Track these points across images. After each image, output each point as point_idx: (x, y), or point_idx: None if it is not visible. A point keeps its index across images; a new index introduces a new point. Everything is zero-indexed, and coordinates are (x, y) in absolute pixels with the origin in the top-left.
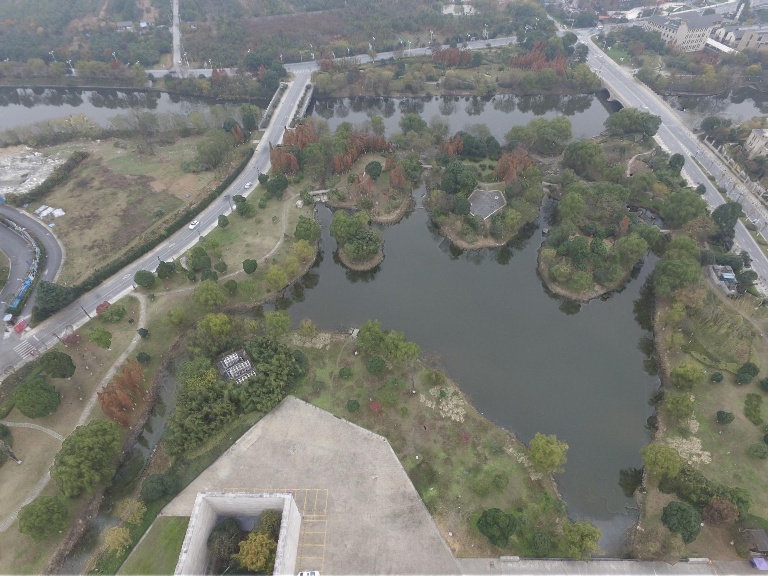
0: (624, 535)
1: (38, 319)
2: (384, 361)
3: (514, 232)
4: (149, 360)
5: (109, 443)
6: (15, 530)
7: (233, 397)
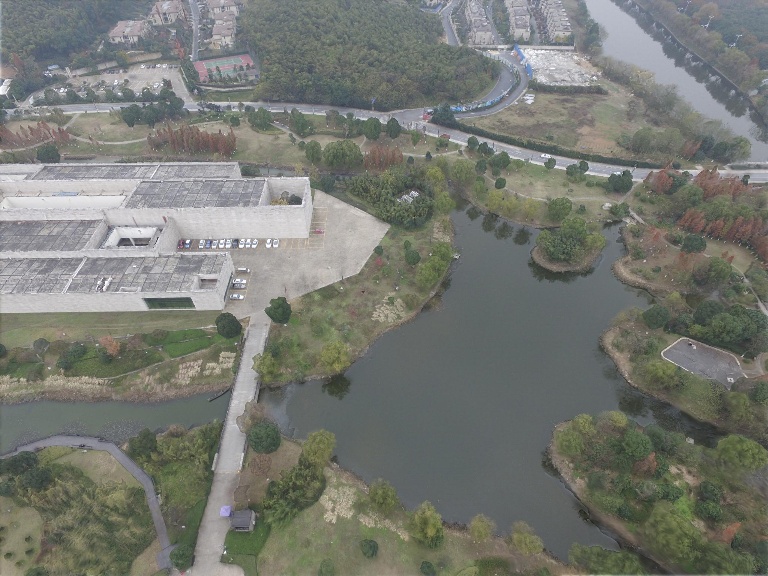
0: (274, 419)
1: (432, 120)
2: (416, 260)
3: (644, 381)
4: None
5: (347, 156)
6: None
7: None
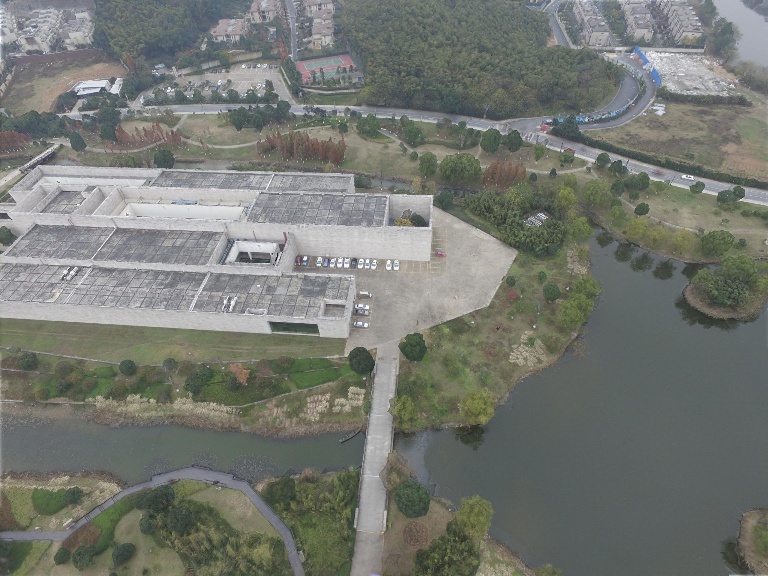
0: (412, 471)
1: (552, 131)
2: (556, 296)
3: None
4: None
5: (466, 170)
6: None
7: None
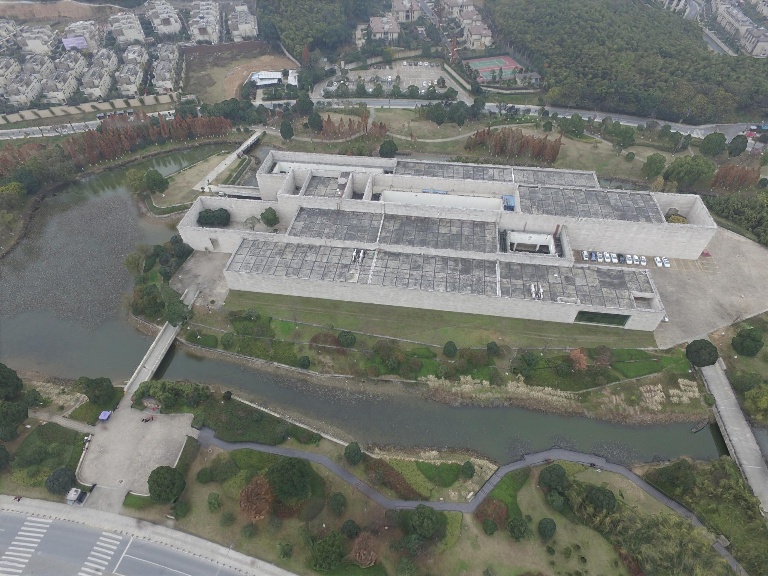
0: None
1: (761, 138)
2: None
3: None
4: (763, 188)
5: (703, 172)
6: (642, 164)
7: (763, 220)
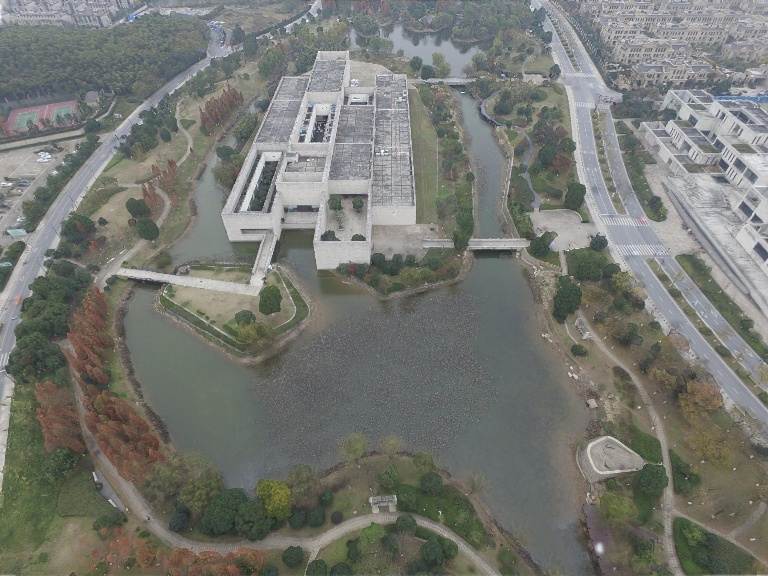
0: None
1: (234, 43)
2: (379, 46)
3: (440, 23)
4: None
5: (281, 55)
6: (252, 76)
7: None
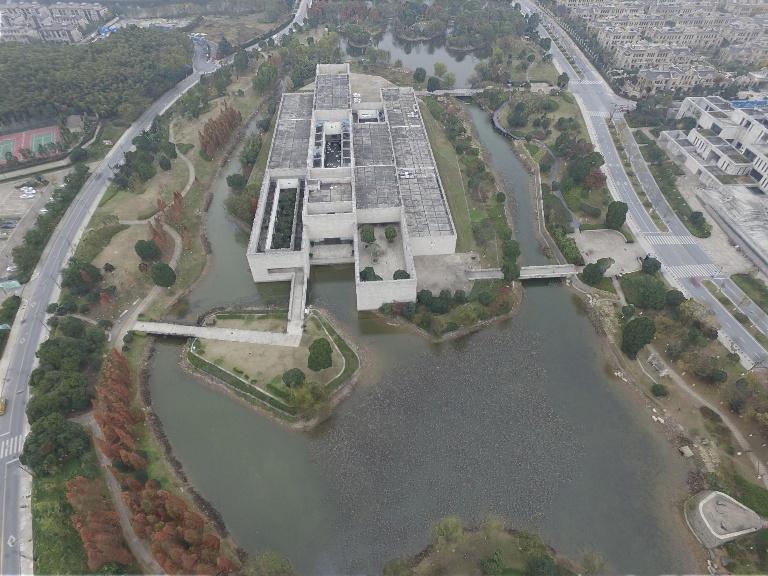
0: None
1: (220, 56)
2: None
3: (434, 31)
4: None
5: (275, 69)
6: None
7: None
